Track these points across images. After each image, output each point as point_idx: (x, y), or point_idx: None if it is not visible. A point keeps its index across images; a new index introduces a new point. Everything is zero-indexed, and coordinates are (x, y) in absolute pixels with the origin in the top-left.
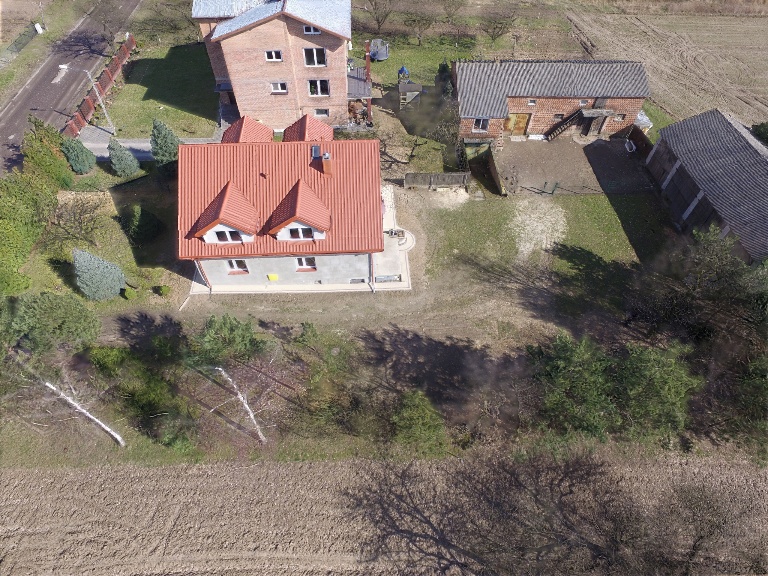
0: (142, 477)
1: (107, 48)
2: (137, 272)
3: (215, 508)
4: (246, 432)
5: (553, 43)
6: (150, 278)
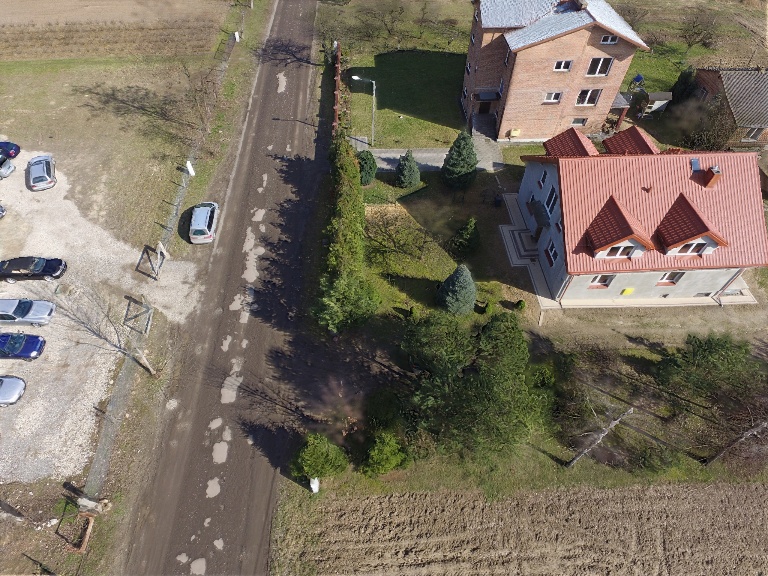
0: (604, 499)
1: (311, 56)
2: None
3: (695, 532)
4: (681, 452)
5: (743, 49)
6: (492, 292)
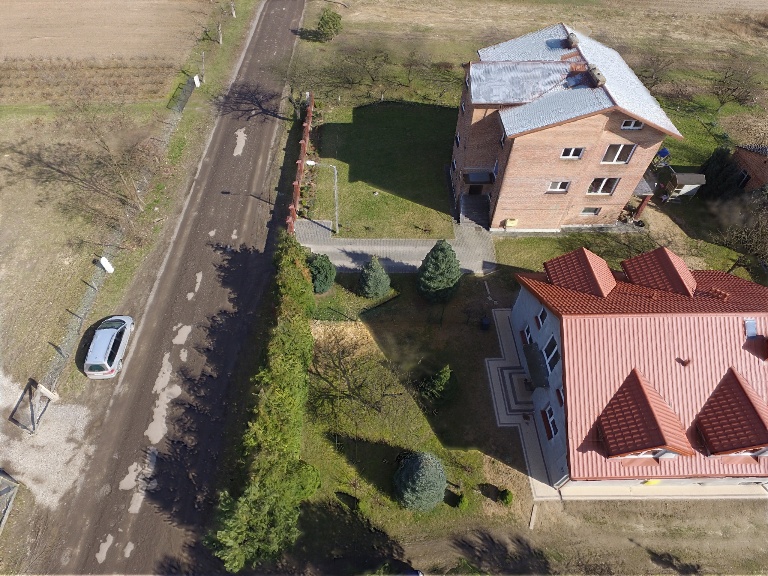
0: None
1: (280, 107)
2: (447, 457)
3: None
4: None
5: None
6: (469, 469)
